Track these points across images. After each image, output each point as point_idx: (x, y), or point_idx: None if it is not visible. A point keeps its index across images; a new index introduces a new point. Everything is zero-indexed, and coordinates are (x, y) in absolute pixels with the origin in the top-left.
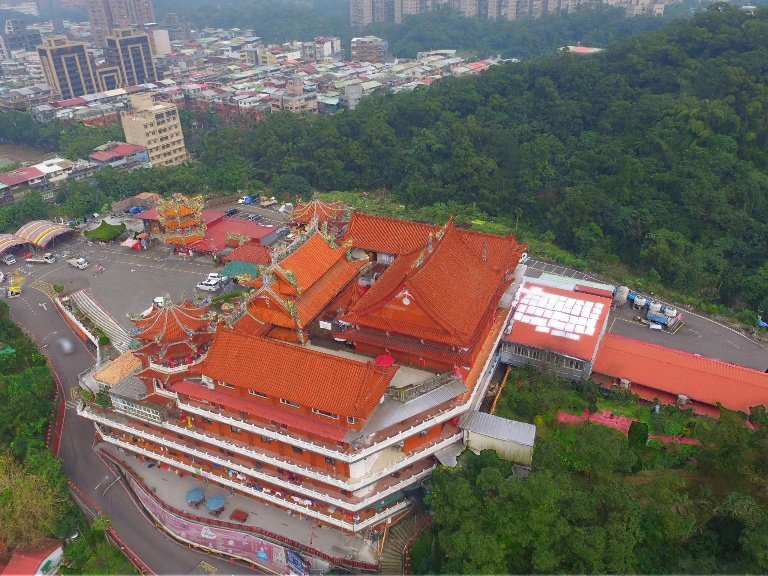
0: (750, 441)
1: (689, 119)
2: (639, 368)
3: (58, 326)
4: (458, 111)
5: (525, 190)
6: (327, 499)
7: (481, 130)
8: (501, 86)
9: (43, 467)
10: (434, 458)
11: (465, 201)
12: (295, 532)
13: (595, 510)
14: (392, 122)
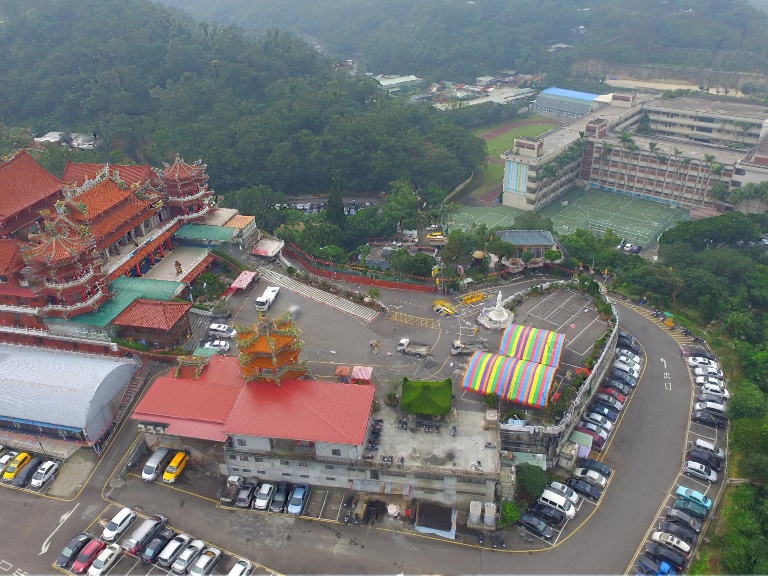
0: None
1: None
2: None
3: None
4: None
5: None
6: None
7: None
8: None
9: None
10: None
11: None
12: None
13: None
14: None
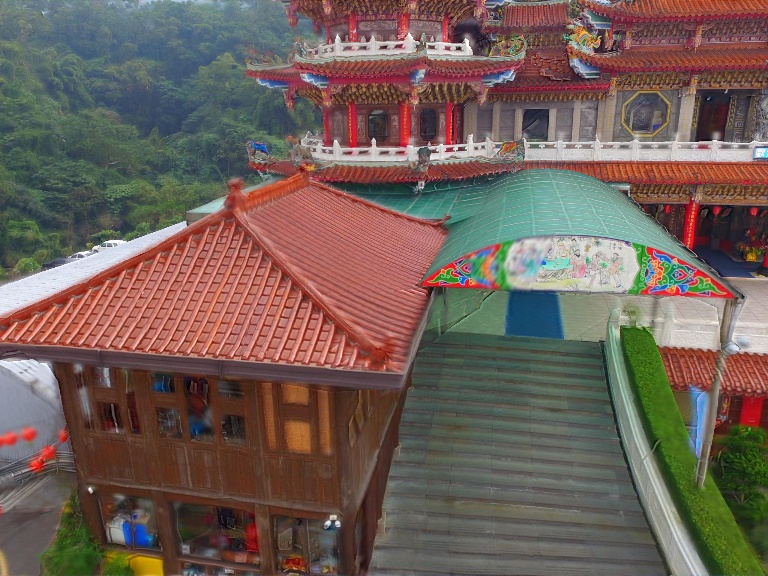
0: None
1: None
2: None
3: None
4: None
5: None
6: None
7: None
8: None
9: None
10: None
11: None
12: None
13: None
14: None
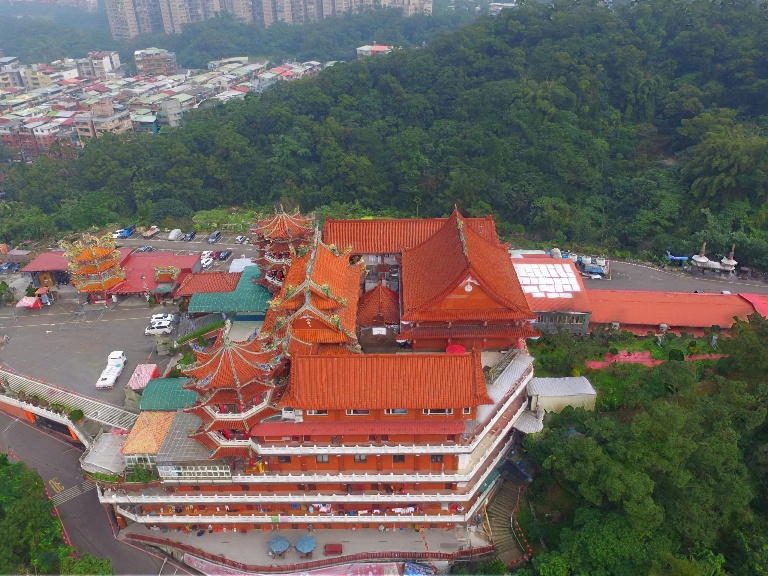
0: (760, 341)
1: (536, 100)
2: (620, 311)
3: None
4: (311, 114)
5: (405, 181)
6: (438, 498)
7: (344, 130)
8: (347, 86)
9: (90, 574)
10: (513, 430)
11: (342, 201)
12: (397, 545)
13: (699, 425)
14: (239, 132)
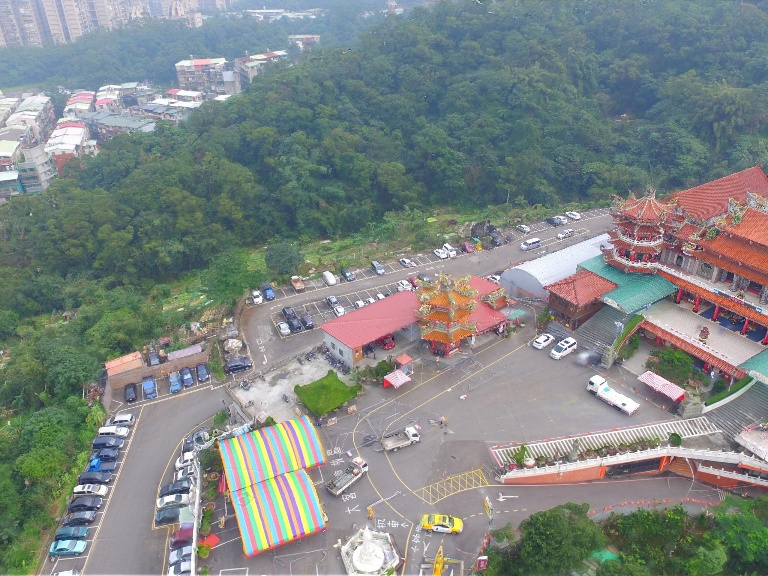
0: None
1: (532, 83)
2: None
3: (565, 494)
4: (299, 130)
5: (449, 177)
6: None
7: None
8: (319, 96)
9: None
10: None
11: (377, 212)
12: None
13: None
14: None
